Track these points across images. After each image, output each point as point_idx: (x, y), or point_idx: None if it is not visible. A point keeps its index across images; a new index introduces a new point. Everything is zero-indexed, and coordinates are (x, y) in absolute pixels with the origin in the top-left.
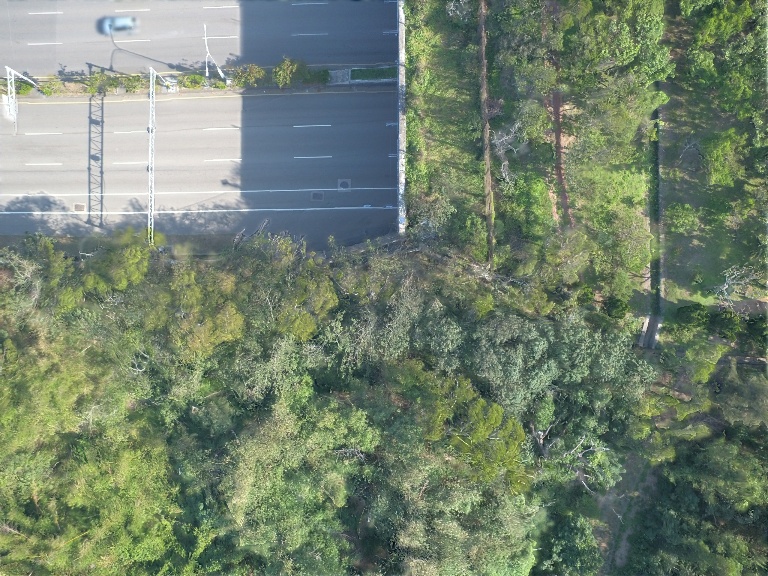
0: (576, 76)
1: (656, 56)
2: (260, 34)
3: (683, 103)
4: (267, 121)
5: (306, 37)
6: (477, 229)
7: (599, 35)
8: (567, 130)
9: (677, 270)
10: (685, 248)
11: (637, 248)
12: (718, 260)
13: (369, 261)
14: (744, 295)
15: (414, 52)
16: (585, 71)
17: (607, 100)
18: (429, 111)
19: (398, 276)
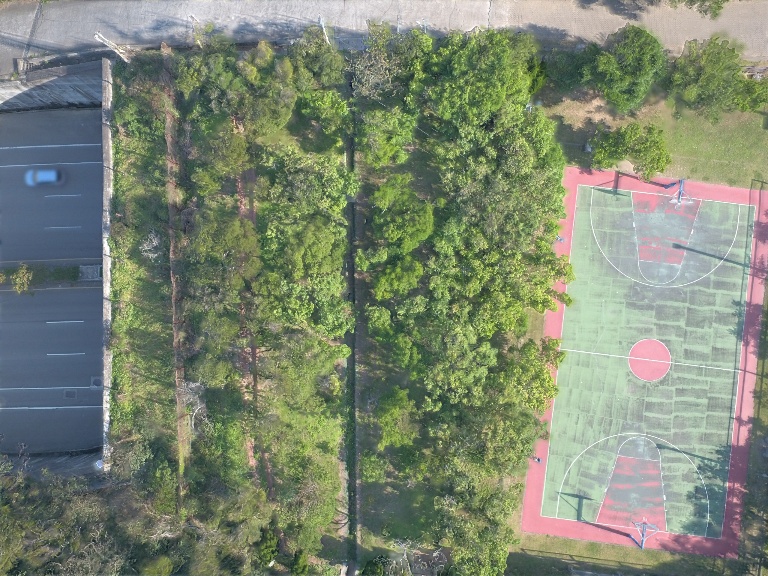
0: (254, 332)
1: (328, 317)
2: (13, 227)
3: (377, 347)
4: (20, 317)
5: (59, 230)
6: (165, 481)
7: (271, 295)
8: (263, 373)
9: (372, 517)
10: (380, 495)
11: (316, 508)
12: (412, 508)
13: (70, 504)
14: (437, 544)
15: (118, 286)
16: (263, 327)
17: (275, 365)
18: (135, 345)
19: (89, 528)
